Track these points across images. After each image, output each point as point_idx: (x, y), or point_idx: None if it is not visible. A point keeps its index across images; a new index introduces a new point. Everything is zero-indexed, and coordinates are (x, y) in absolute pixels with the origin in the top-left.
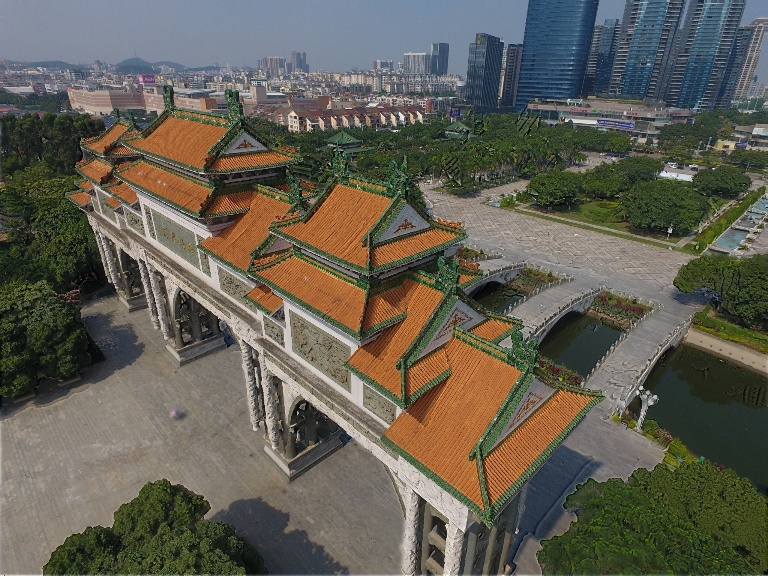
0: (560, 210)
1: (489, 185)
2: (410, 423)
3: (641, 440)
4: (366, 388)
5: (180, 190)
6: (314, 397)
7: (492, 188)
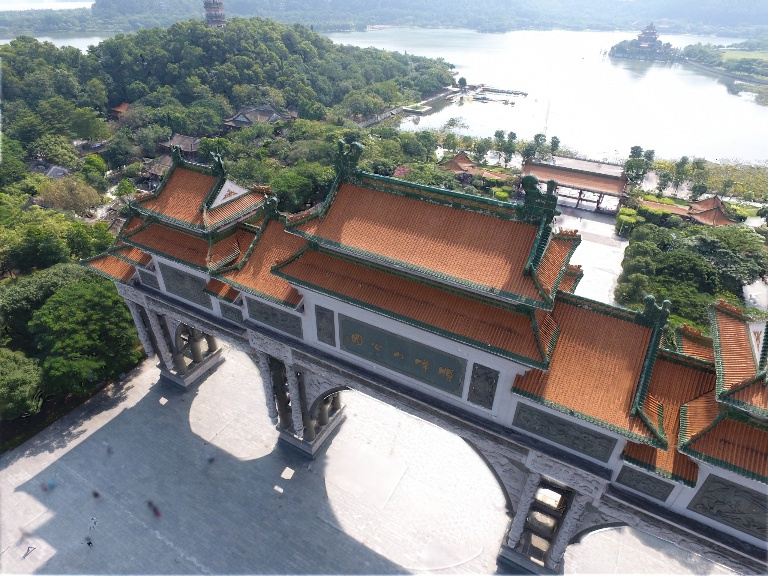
0: None
1: None
2: None
3: None
4: None
5: None
6: None
7: None
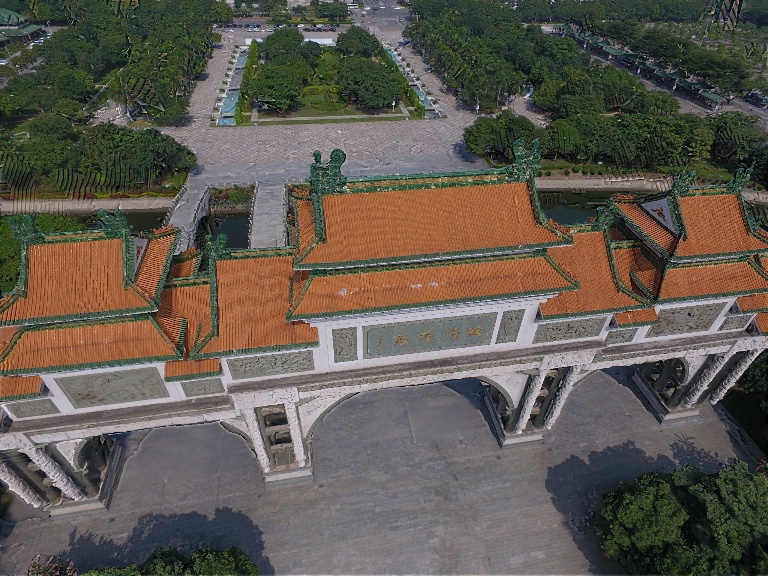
0: (291, 109)
1: (182, 100)
2: (763, 317)
3: None
4: (728, 319)
5: (481, 278)
6: (652, 356)
7: (188, 103)
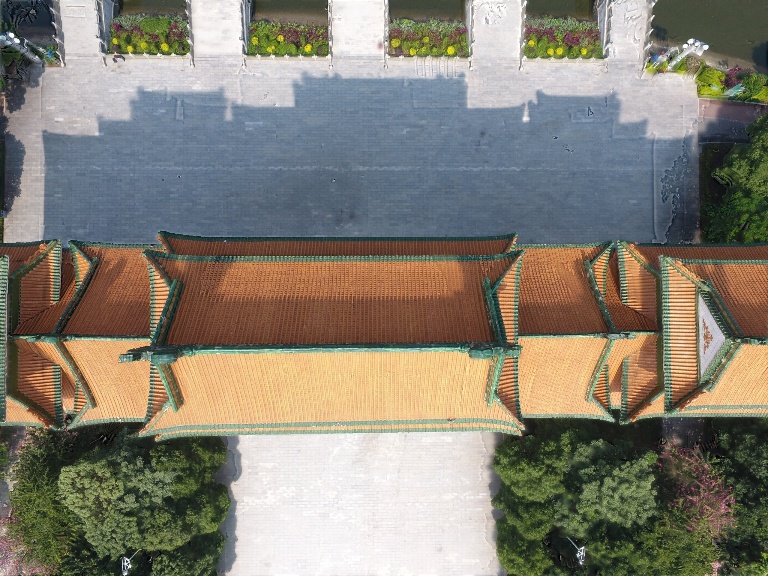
0: None
1: None
2: None
3: (675, 81)
4: None
5: None
6: None
7: None
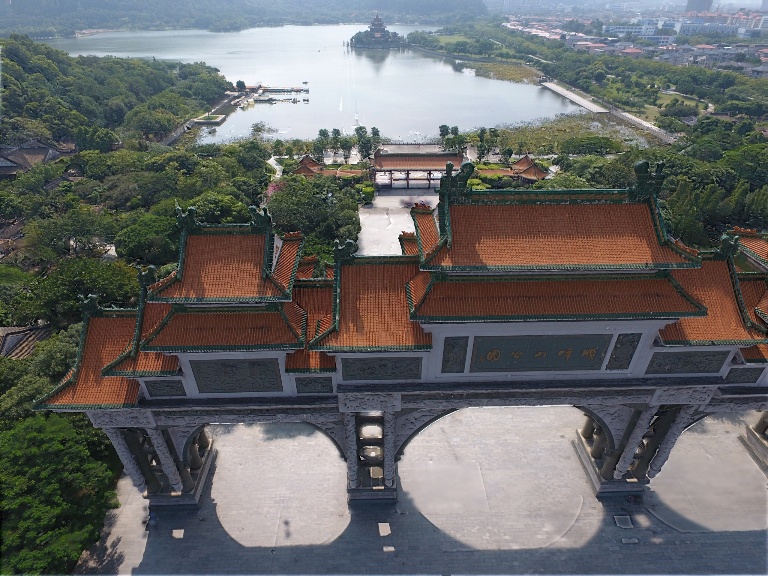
0: None
1: None
2: None
3: None
4: None
5: None
6: None
7: None
